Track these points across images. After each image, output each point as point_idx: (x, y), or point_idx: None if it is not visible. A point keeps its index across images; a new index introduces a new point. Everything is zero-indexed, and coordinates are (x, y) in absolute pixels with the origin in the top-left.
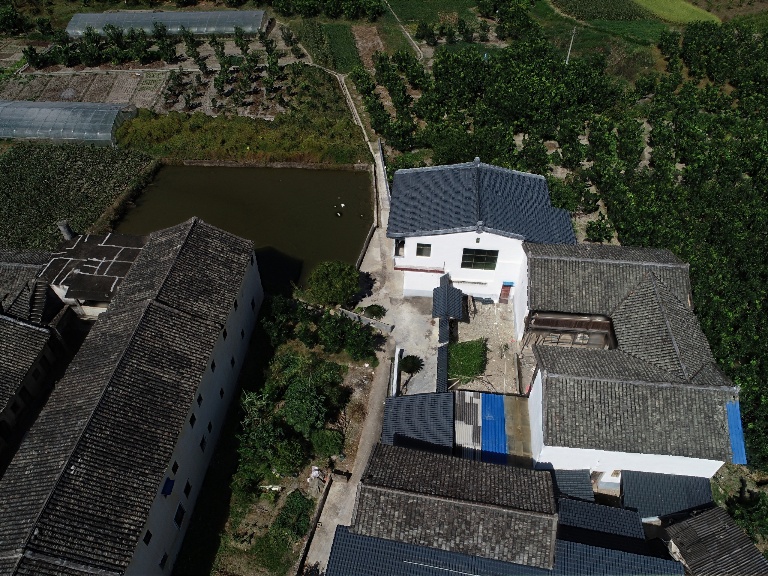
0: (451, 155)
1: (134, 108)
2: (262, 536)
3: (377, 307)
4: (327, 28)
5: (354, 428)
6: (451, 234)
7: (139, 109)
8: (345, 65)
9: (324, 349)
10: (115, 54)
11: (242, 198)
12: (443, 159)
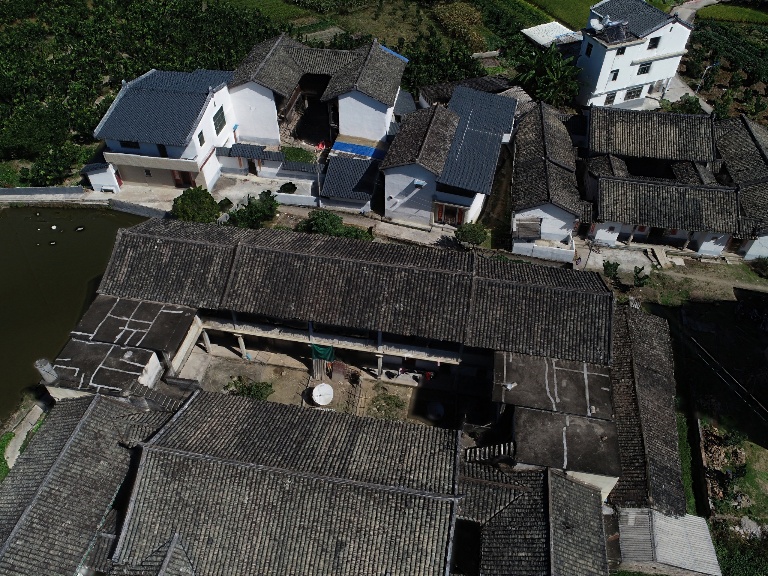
0: (46, 136)
1: None
2: None
3: (223, 200)
4: None
5: None
6: (205, 111)
7: None
8: None
9: None
10: None
11: None
12: (45, 143)
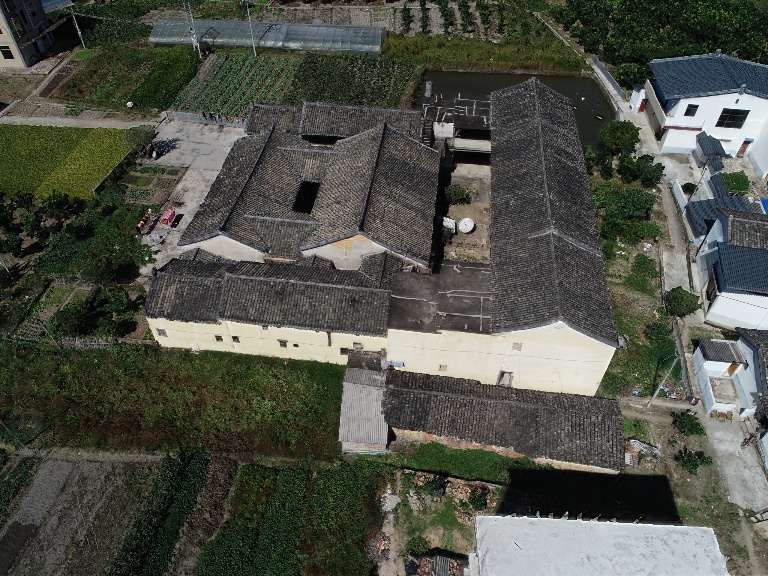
0: None
1: (385, 30)
2: (628, 276)
3: (649, 156)
4: None
5: (662, 224)
6: (718, 96)
7: (388, 31)
8: (536, 5)
9: (624, 177)
10: None
11: None
12: None
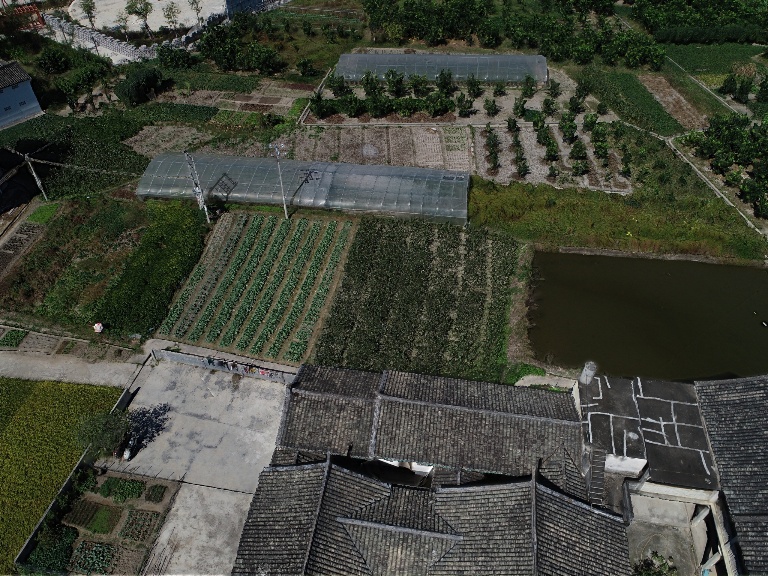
0: None
1: None
2: None
3: None
4: (612, 77)
5: None
6: None
7: (472, 177)
8: (663, 125)
9: None
10: (407, 105)
11: (651, 300)
12: None
